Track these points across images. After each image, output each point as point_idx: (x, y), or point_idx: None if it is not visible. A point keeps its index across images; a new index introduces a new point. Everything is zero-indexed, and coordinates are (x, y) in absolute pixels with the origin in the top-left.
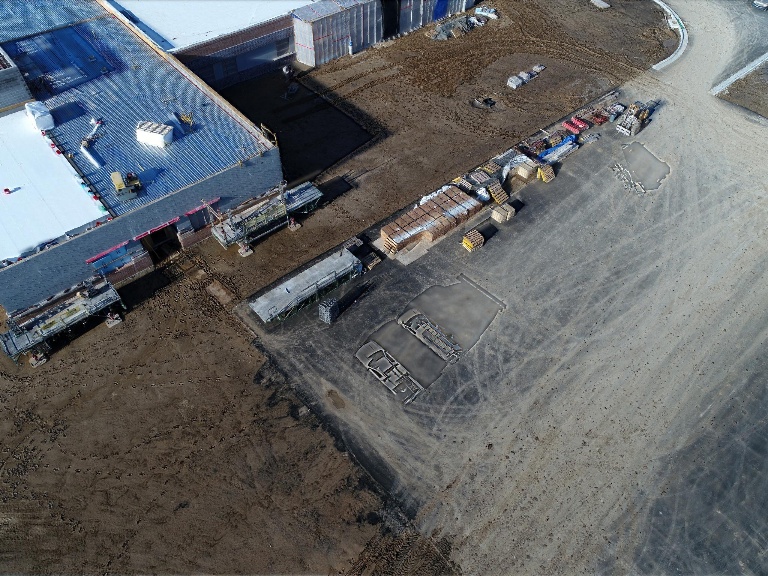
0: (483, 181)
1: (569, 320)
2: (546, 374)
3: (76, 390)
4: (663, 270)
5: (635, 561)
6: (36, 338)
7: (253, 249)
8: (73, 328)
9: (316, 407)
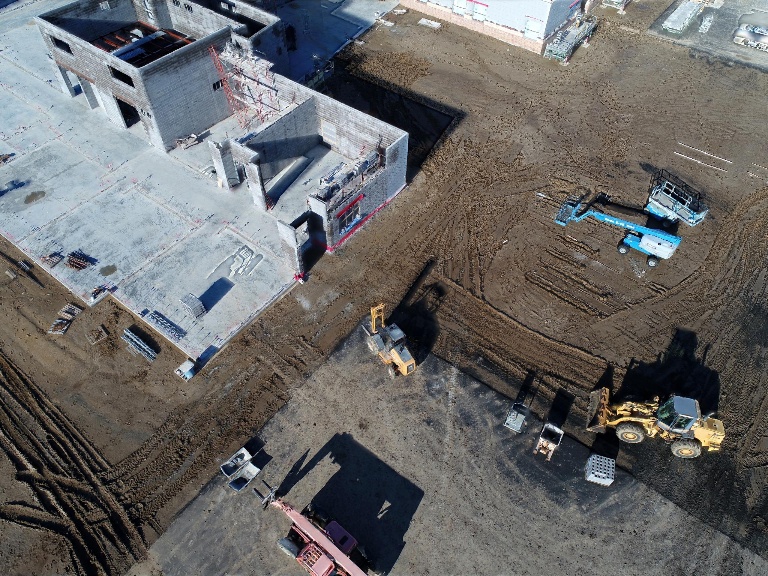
0: None
1: None
2: None
3: (600, 72)
4: None
5: None
6: None
7: (625, 11)
8: None
9: (737, 61)
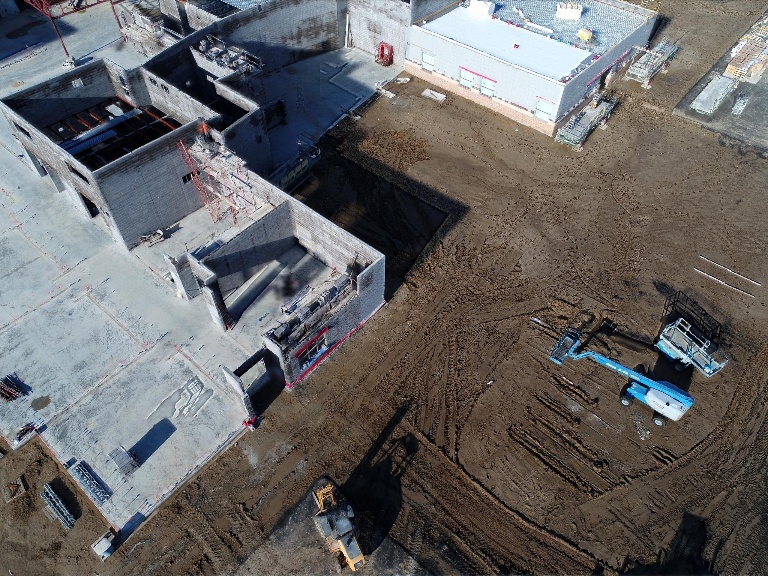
0: (767, 35)
1: None
2: None
3: (617, 160)
4: None
5: None
6: None
7: (650, 85)
8: None
9: None
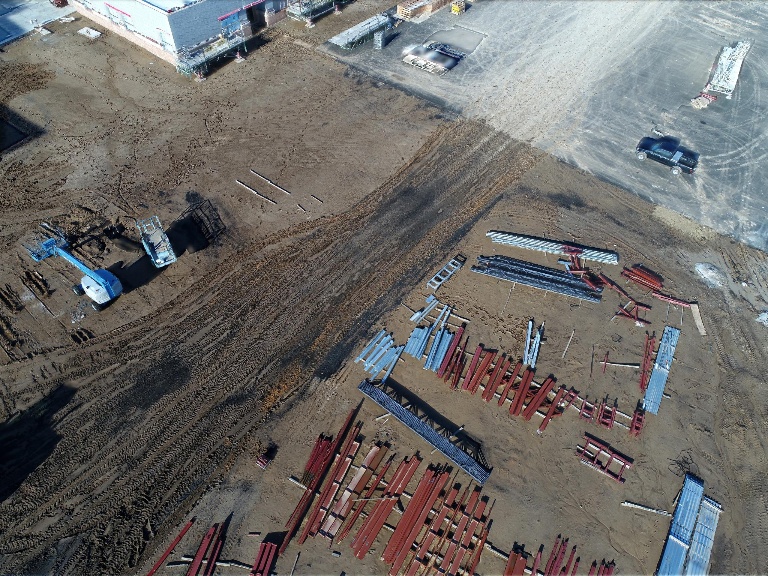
0: None
1: (527, 38)
2: (520, 59)
3: (233, 89)
4: (579, 14)
5: (585, 116)
6: (202, 58)
7: (315, 24)
8: (215, 64)
9: (388, 81)
